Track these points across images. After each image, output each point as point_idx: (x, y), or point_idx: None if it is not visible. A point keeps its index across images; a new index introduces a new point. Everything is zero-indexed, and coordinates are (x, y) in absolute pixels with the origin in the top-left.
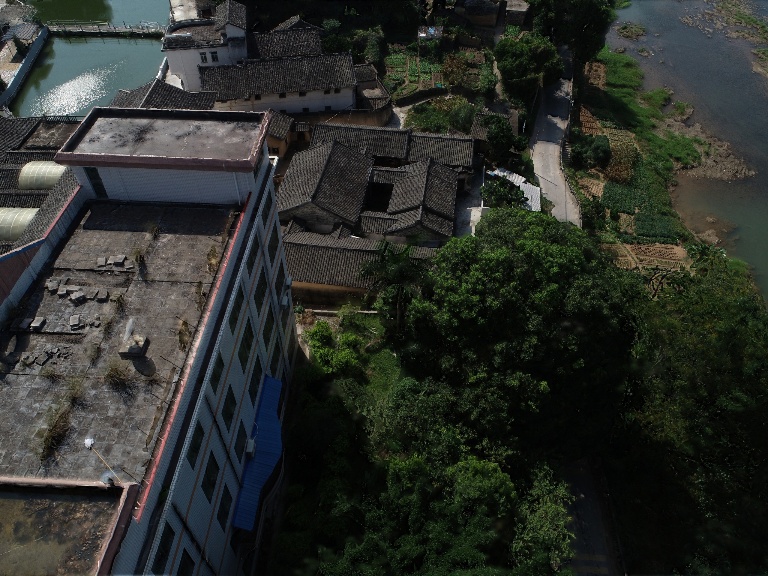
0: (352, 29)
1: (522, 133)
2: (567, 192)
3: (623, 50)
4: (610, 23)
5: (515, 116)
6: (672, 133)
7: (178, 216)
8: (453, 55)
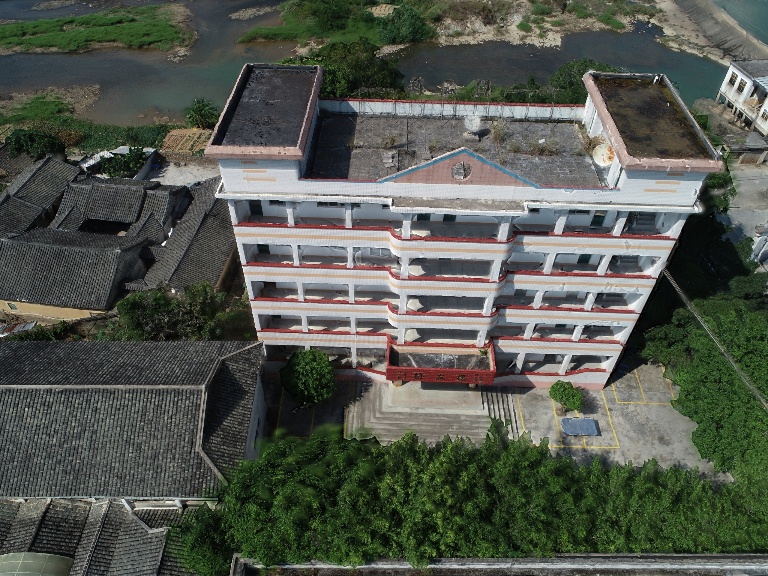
0: None
1: None
2: None
3: None
4: None
5: None
6: (17, 108)
7: (331, 141)
8: None
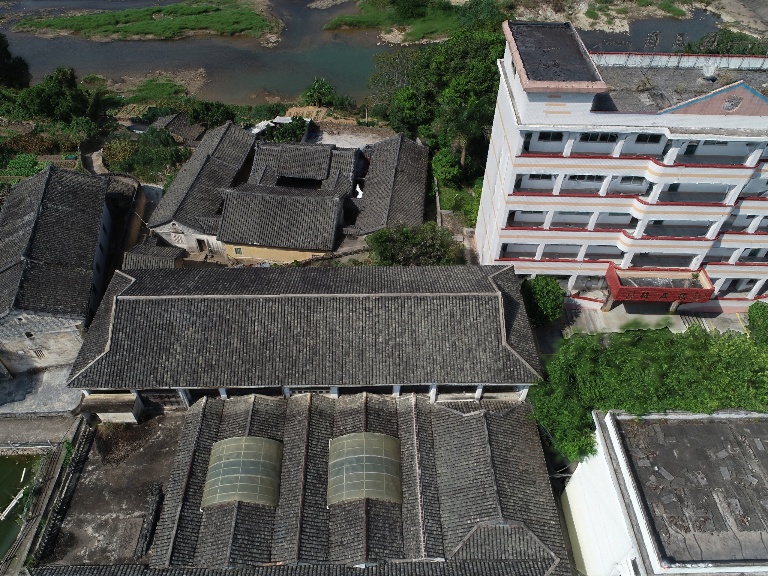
0: None
1: None
2: None
3: None
4: None
5: None
6: None
7: None
8: None
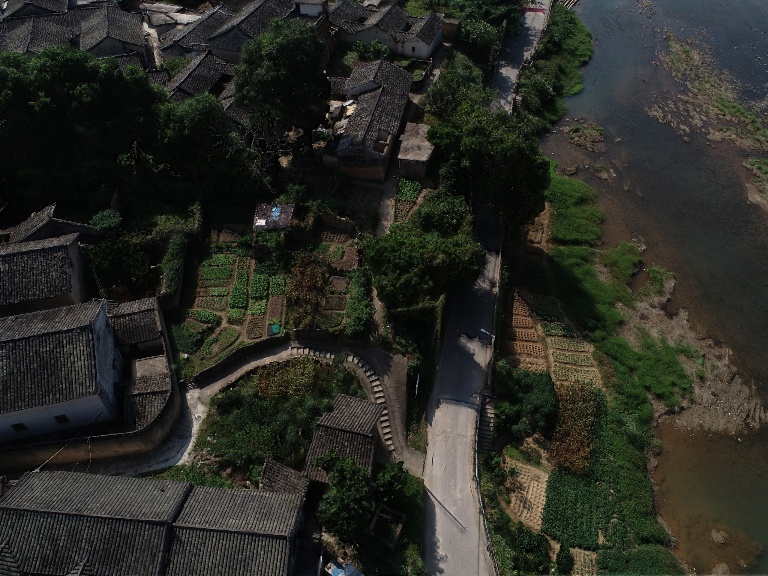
0: (156, 210)
1: (414, 398)
2: (481, 548)
3: (575, 170)
4: (557, 121)
5: (402, 370)
6: (647, 334)
7: None
8: (309, 254)
